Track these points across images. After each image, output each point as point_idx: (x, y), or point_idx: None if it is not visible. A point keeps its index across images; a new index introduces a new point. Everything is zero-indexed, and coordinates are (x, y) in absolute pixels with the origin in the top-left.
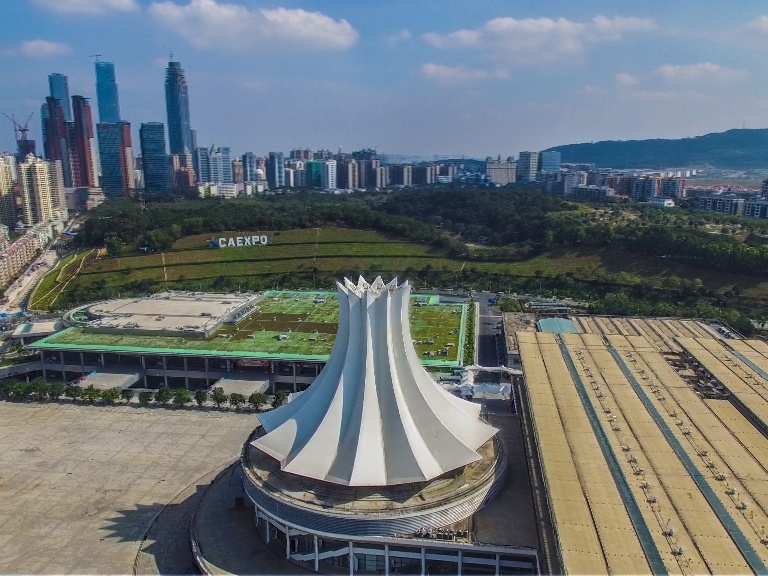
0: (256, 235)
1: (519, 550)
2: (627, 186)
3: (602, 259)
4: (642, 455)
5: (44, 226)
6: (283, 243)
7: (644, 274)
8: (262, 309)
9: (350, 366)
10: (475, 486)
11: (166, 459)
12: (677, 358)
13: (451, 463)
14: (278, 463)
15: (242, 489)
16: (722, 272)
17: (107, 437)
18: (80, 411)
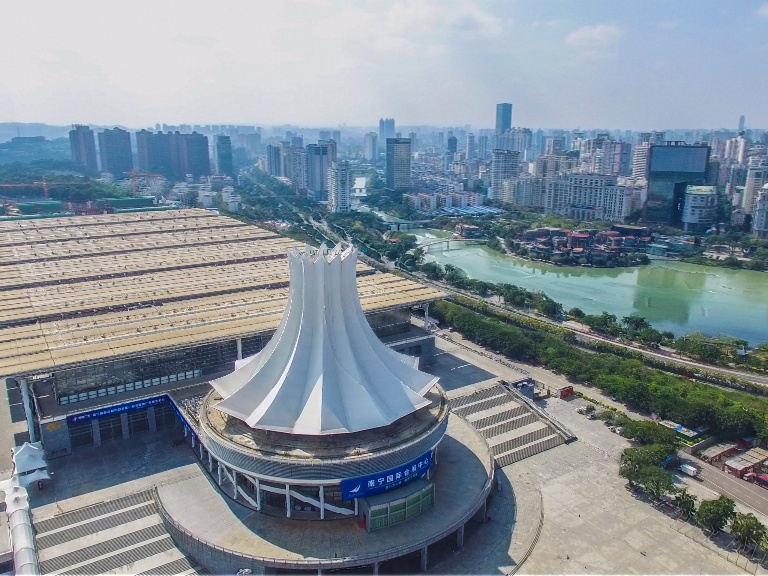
0: None
1: None
2: None
3: None
4: None
5: None
6: None
7: None
8: None
9: None
10: None
11: None
12: None
13: None
14: None
15: None
16: None
17: None
18: None
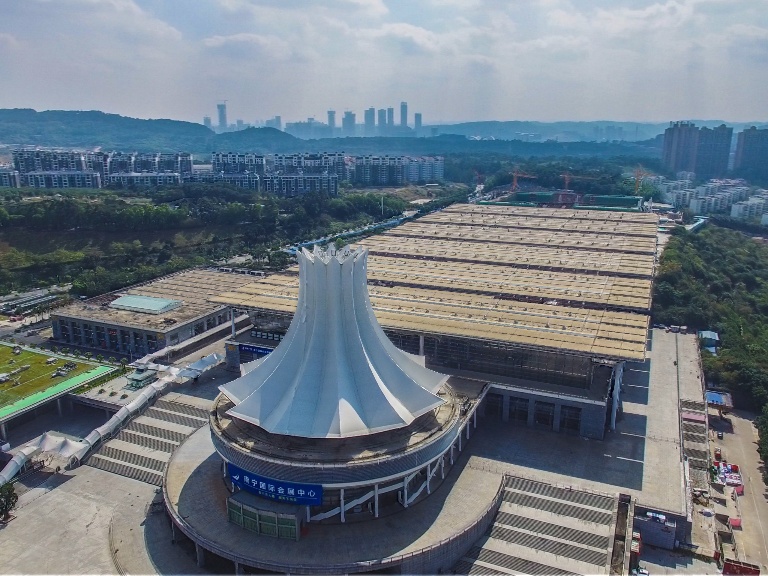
0: None
1: None
2: None
3: (11, 244)
4: None
5: None
6: None
7: (73, 248)
8: None
9: None
10: None
11: None
12: None
13: None
14: (358, 442)
15: None
16: (139, 232)
17: None
18: None
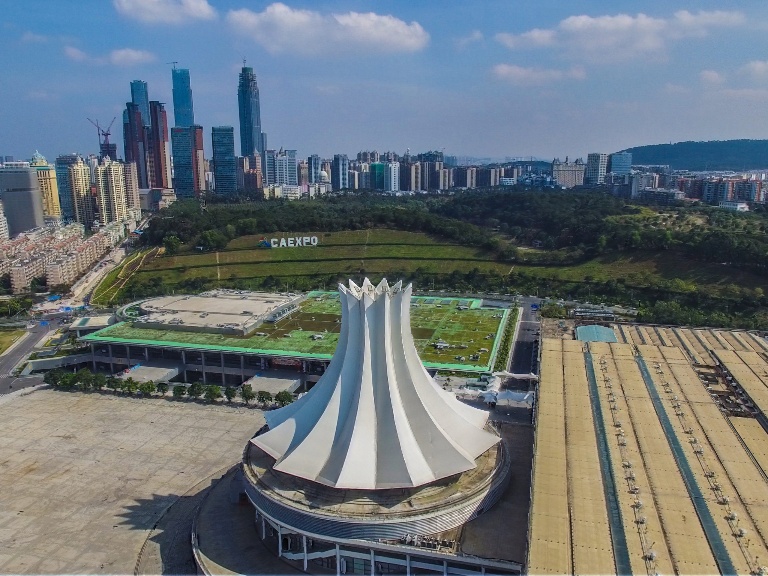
0: (307, 236)
1: (503, 564)
2: (699, 189)
3: (657, 265)
4: (643, 473)
5: (116, 225)
6: (333, 244)
7: (701, 282)
8: (303, 309)
9: (348, 368)
10: (467, 495)
11: (188, 452)
12: (711, 372)
13: (444, 470)
14: None
15: None
16: None
17: (138, 428)
18: (118, 402)
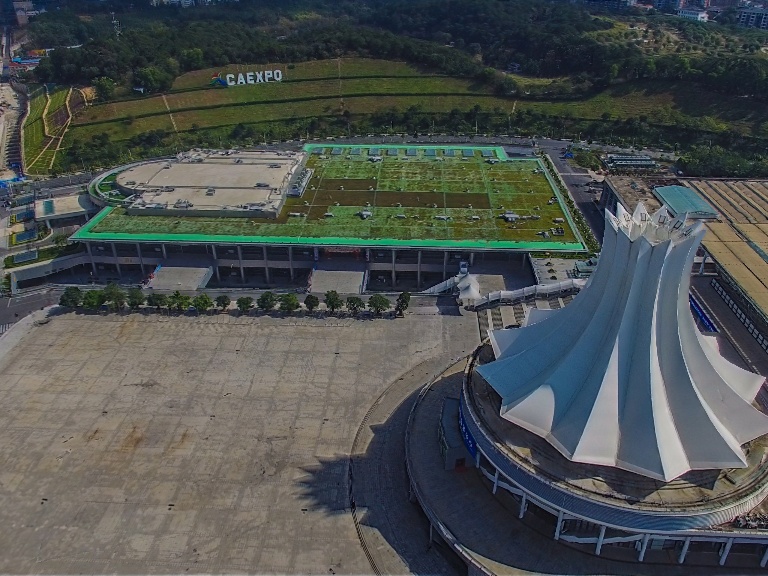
0: (268, 69)
1: None
2: None
3: (675, 98)
4: None
5: None
6: (301, 79)
7: (726, 118)
8: (318, 173)
9: (626, 325)
10: None
11: (313, 389)
12: None
13: (746, 433)
14: (534, 436)
15: (474, 456)
16: None
17: (227, 361)
18: (173, 324)
